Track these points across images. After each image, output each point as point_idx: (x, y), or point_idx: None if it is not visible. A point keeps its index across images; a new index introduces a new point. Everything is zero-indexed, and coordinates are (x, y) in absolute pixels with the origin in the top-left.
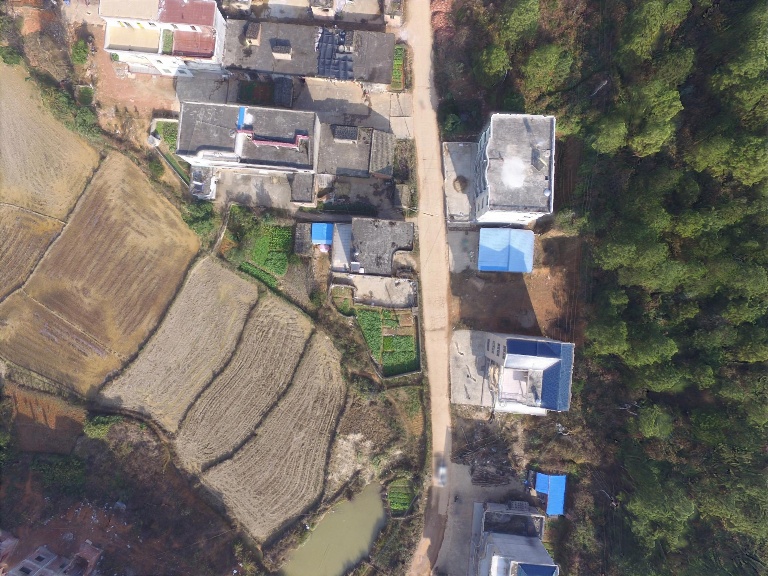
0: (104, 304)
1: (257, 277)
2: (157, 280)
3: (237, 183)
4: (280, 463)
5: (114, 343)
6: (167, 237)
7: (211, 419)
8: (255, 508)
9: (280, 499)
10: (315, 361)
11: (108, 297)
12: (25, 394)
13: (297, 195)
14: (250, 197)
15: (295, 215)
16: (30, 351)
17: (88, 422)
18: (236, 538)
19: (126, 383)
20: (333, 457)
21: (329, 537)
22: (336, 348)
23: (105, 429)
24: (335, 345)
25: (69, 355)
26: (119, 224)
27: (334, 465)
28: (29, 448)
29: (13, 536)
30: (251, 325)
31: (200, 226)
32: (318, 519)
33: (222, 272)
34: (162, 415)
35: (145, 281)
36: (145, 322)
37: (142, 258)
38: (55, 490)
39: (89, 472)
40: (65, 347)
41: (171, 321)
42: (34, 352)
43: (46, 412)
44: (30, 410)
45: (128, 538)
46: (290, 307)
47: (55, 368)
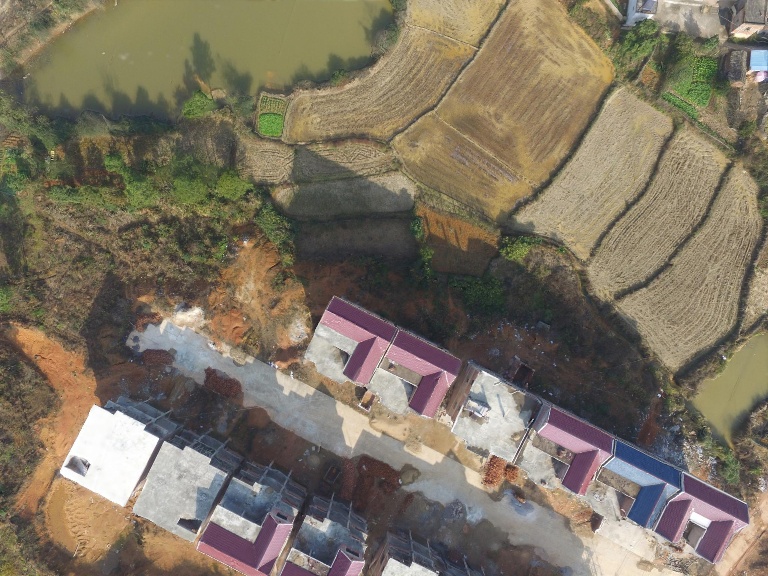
0: (516, 130)
1: (679, 107)
2: (570, 109)
3: (666, 11)
4: (695, 294)
5: (525, 170)
6: (581, 67)
7: (625, 248)
8: (669, 338)
9: (694, 330)
10: (732, 194)
11: (520, 123)
12: (436, 215)
13: (749, 17)
14: (678, 26)
15: (723, 46)
16: (441, 173)
17: (515, 240)
18: (651, 366)
19: (539, 209)
20: (751, 289)
21: (739, 371)
22: (760, 180)
23: (526, 250)
24: (762, 176)
25: (480, 179)
26: (533, 52)
27: (751, 298)
28: (440, 269)
29: (444, 347)
30: (667, 156)
31: (648, 44)
32: (737, 349)
33: (637, 103)
34: (574, 242)
35: (558, 109)
36: (556, 150)
37: (555, 86)
38: (477, 307)
39: (507, 293)
40: (476, 171)
41: (585, 149)
42: (444, 175)
43: (458, 234)
44: (442, 231)
45: (554, 357)
46: (706, 141)
47: (465, 191)
